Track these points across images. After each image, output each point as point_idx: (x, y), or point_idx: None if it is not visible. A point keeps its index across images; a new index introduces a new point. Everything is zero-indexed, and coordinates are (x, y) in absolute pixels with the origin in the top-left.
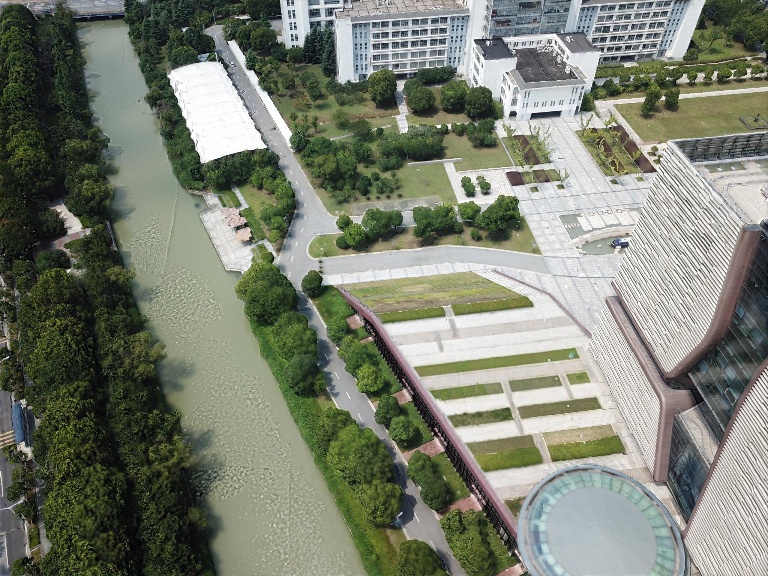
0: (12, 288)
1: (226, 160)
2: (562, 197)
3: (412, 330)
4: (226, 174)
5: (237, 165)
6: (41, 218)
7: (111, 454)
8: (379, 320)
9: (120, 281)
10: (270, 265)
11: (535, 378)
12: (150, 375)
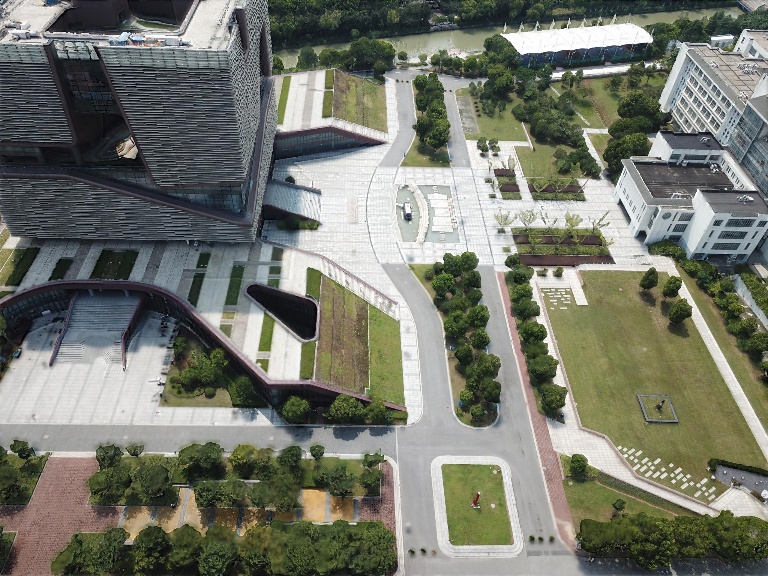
0: (403, 7)
1: (499, 38)
2: (477, 193)
3: (318, 78)
4: (491, 44)
5: (499, 45)
6: (451, 2)
7: (280, 18)
8: None
9: (388, 16)
10: (388, 48)
11: None
12: (320, 24)
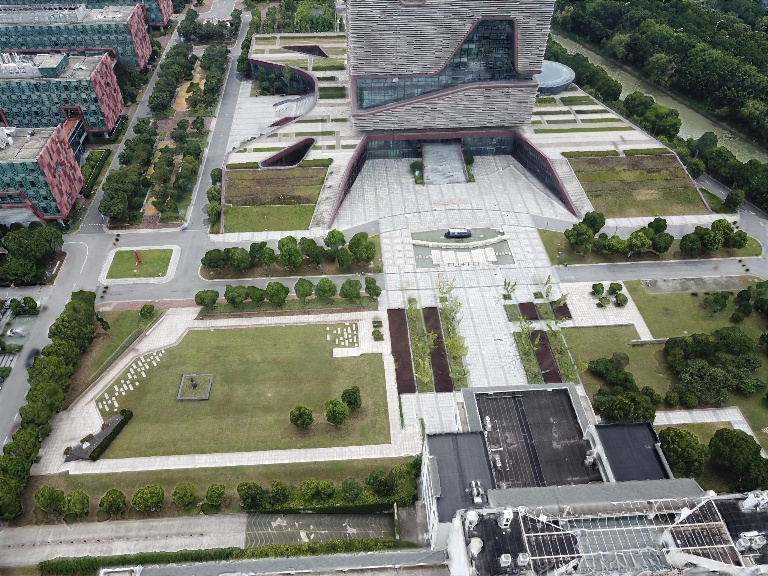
0: None
1: None
2: None
3: (644, 145)
4: None
5: None
6: None
7: None
8: (669, 150)
9: None
10: None
11: (561, 123)
12: None
